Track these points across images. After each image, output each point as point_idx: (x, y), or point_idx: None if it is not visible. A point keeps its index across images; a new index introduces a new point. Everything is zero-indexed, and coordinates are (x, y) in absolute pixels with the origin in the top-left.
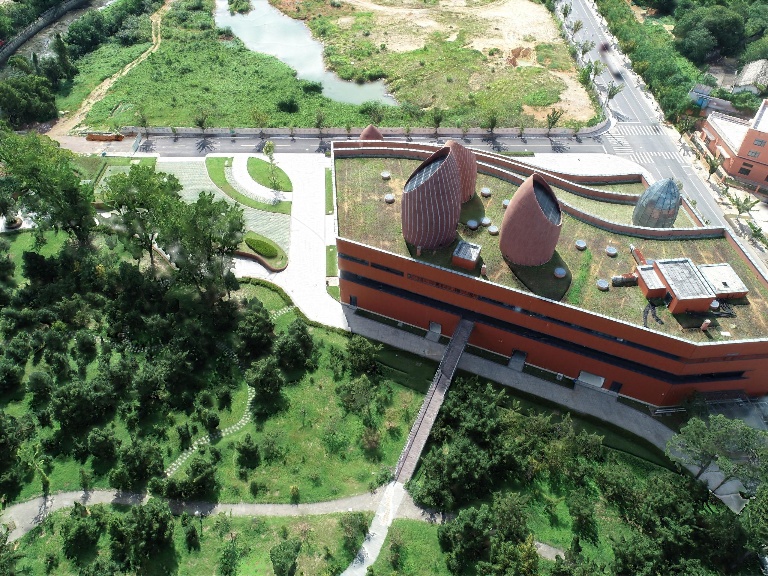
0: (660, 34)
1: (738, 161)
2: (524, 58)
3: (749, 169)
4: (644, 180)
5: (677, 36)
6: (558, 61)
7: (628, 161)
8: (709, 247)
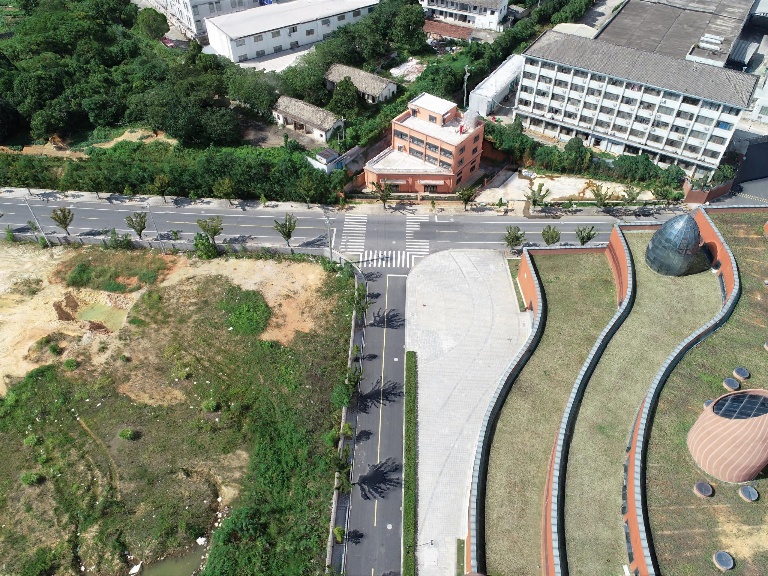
0: (147, 149)
1: (455, 177)
2: (79, 310)
3: (461, 176)
4: (536, 251)
5: (180, 136)
6: (137, 268)
7: (425, 261)
8: (728, 228)
